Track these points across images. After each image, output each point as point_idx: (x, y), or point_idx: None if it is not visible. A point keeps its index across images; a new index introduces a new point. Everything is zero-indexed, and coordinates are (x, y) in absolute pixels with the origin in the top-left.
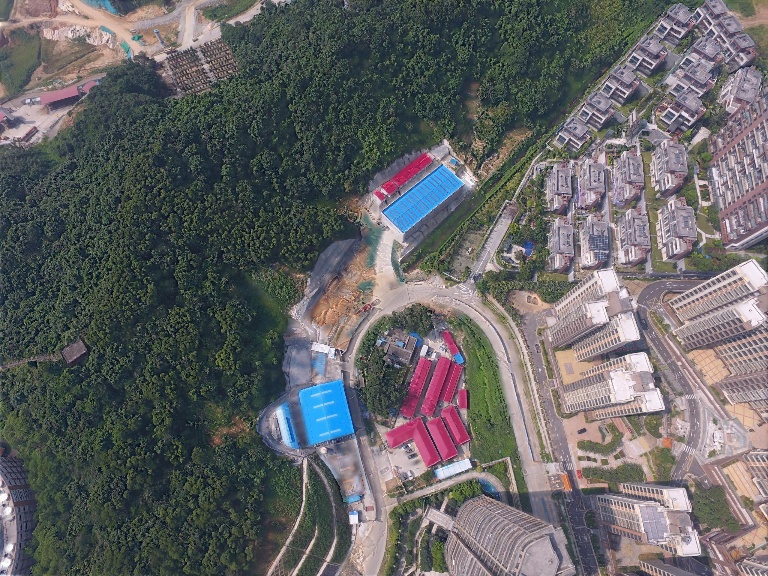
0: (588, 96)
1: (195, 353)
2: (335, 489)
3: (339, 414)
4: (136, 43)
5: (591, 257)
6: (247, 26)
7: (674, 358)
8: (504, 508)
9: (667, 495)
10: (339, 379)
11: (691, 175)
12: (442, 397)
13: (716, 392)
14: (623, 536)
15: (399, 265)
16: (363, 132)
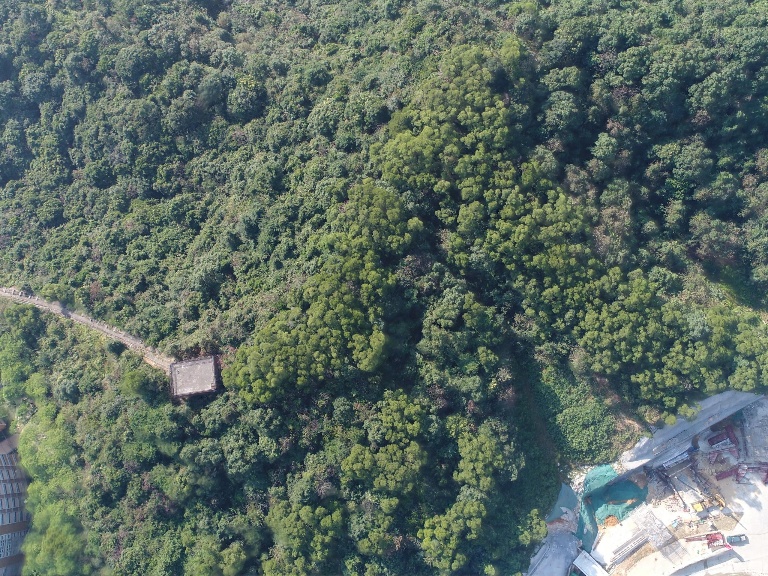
0: None
1: (396, 503)
2: None
3: None
4: None
5: None
6: None
7: None
8: None
9: None
10: None
11: None
12: None
13: None
14: None
15: None
16: None
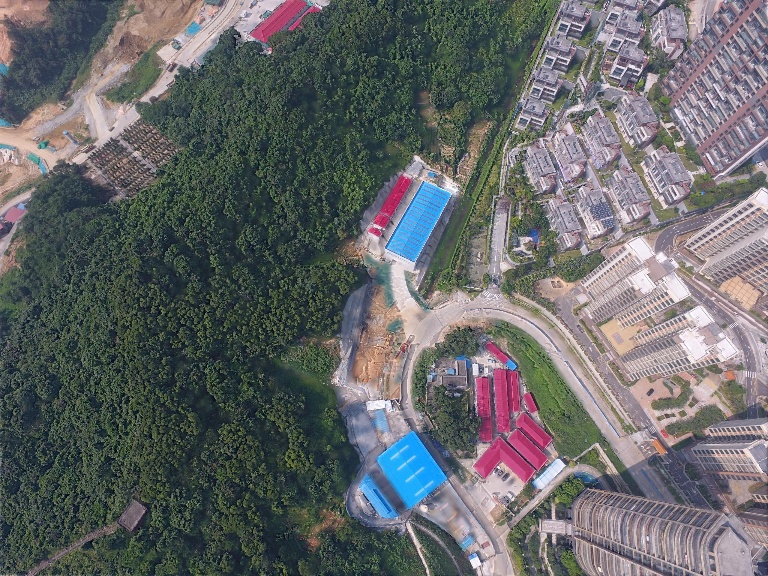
0: (531, 73)
1: (264, 465)
2: (447, 541)
3: (425, 466)
4: (45, 151)
5: (598, 226)
6: (167, 100)
7: (707, 295)
8: (636, 502)
9: (767, 429)
10: (405, 429)
11: (658, 121)
12: (511, 409)
13: (757, 314)
14: (736, 479)
15: (418, 294)
16: (339, 175)
